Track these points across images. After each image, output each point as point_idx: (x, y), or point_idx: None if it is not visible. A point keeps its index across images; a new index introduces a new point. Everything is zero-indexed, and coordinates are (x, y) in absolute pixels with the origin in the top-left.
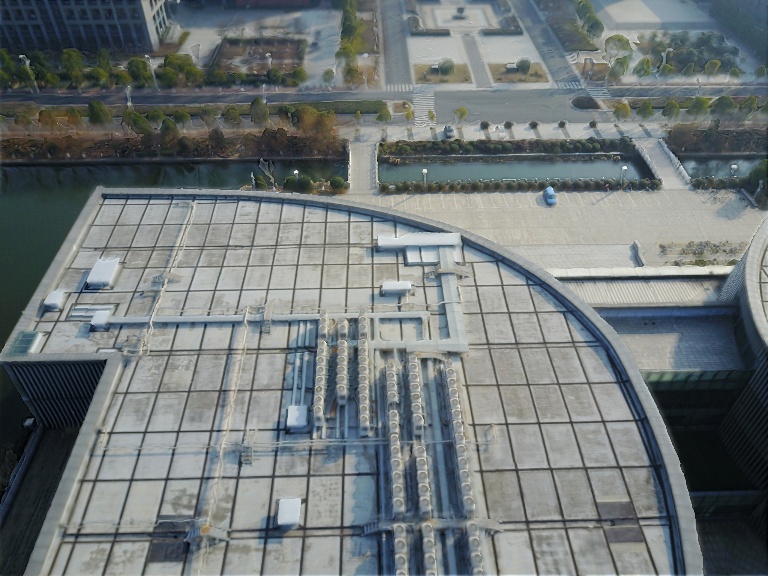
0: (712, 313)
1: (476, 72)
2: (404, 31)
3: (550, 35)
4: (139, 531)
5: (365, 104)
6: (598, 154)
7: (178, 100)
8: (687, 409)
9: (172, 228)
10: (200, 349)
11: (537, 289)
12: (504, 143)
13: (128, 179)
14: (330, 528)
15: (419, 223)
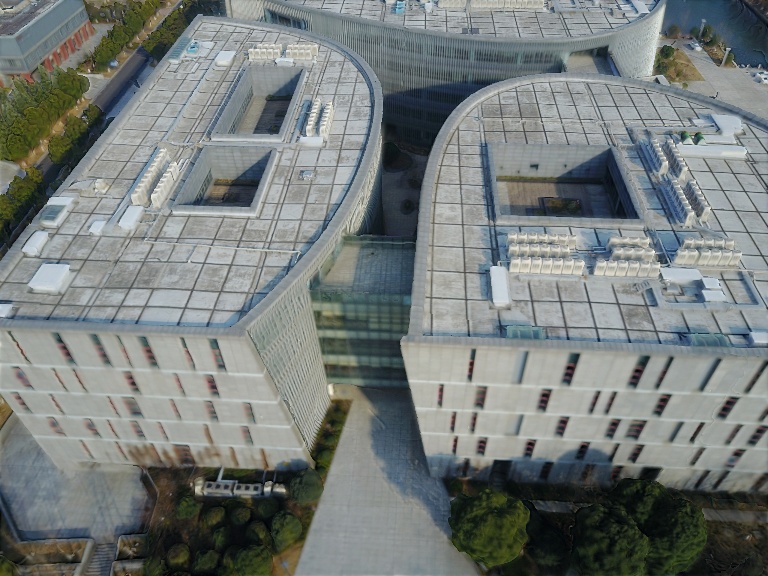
0: None
1: None
2: None
3: None
4: None
5: None
6: None
7: None
8: None
9: None
10: None
11: None
12: None
13: None
14: None
15: None
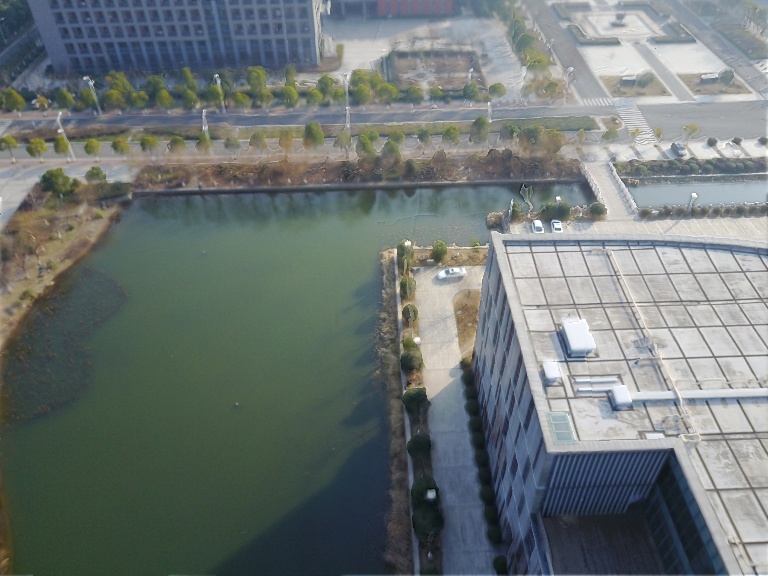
0: None
1: (669, 83)
2: (570, 40)
3: (724, 42)
4: None
5: (574, 120)
6: None
7: (372, 118)
8: None
9: (604, 280)
10: (754, 431)
11: None
12: (745, 161)
13: (345, 204)
14: None
15: None
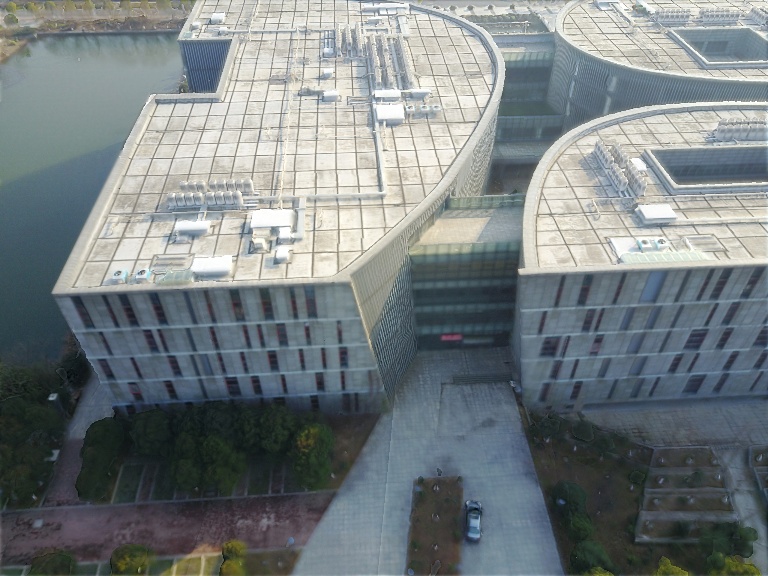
0: (544, 40)
1: None
2: None
3: None
4: (263, 79)
5: None
6: (514, 23)
7: None
8: (528, 83)
9: (249, 6)
10: (276, 39)
11: (448, 21)
12: None
13: None
14: (347, 78)
15: (386, 1)
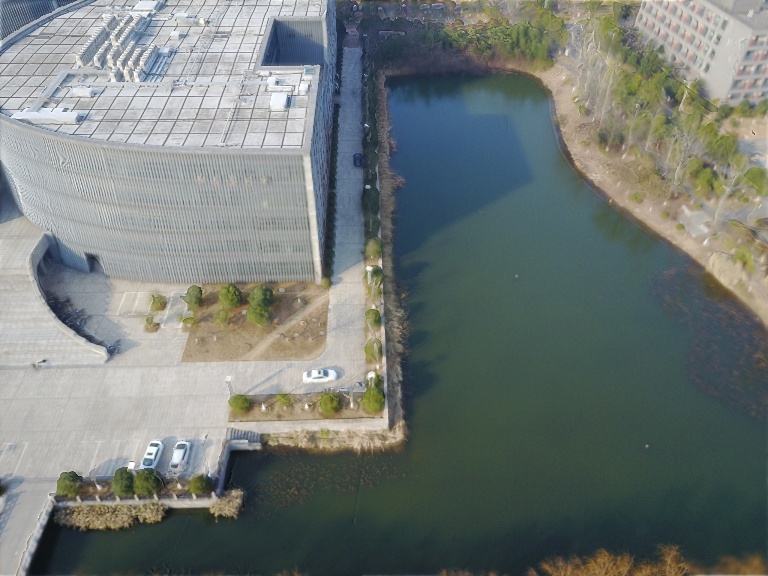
0: None
1: None
2: None
3: None
4: None
5: None
6: None
7: None
8: None
9: (239, 131)
10: None
11: None
12: None
13: None
14: None
15: (36, 126)
